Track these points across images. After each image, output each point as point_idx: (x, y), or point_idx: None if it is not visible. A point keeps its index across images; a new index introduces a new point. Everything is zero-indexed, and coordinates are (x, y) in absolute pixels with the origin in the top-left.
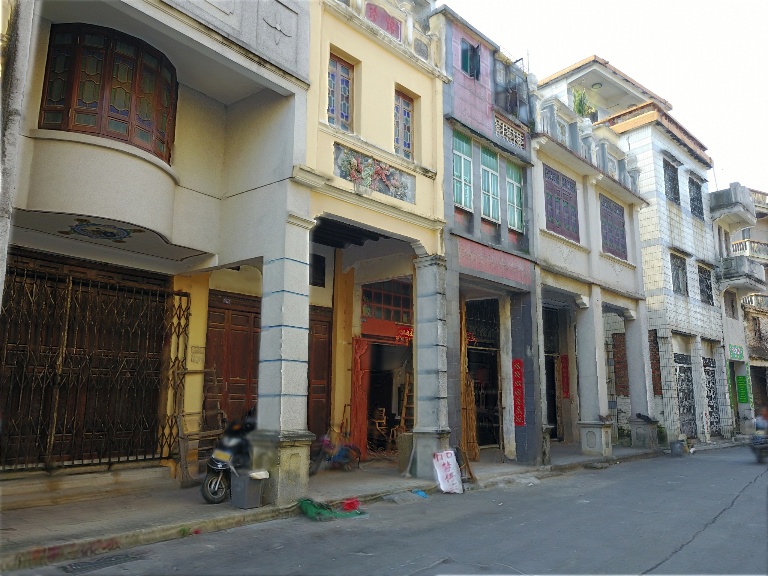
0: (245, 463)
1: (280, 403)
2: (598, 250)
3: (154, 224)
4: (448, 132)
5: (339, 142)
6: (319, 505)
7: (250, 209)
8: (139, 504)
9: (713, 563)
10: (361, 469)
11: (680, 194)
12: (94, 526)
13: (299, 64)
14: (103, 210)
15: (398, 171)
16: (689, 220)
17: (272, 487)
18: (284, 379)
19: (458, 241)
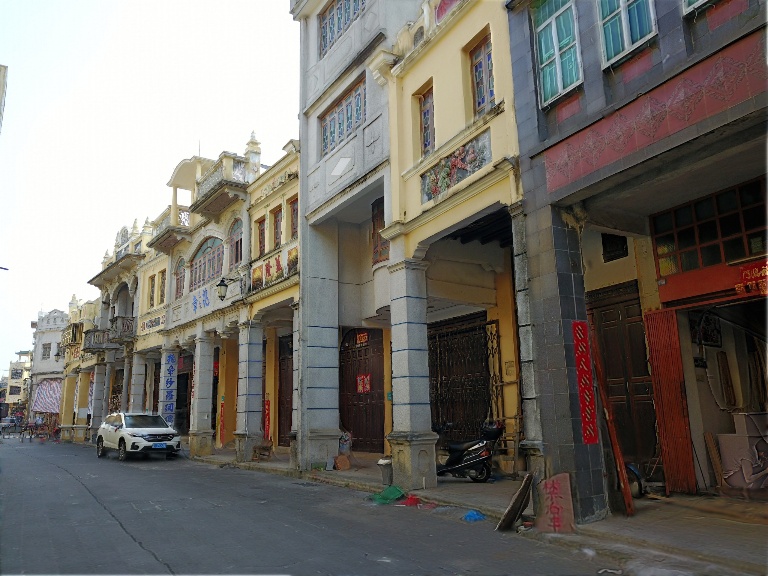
0: None
1: None
2: None
3: None
4: (519, 21)
5: (422, 172)
6: None
7: None
8: None
9: (95, 537)
10: (647, 500)
11: None
12: None
13: (384, 150)
14: None
15: (475, 140)
16: None
17: None
18: (394, 392)
19: (546, 158)
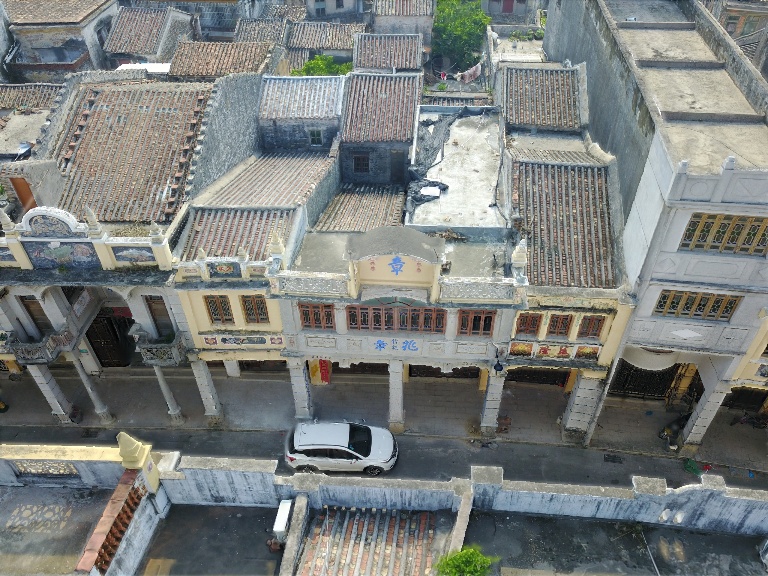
0: (676, 435)
1: (689, 434)
2: None
3: (664, 367)
4: None
5: None
6: (690, 464)
7: (709, 369)
8: (643, 420)
9: None
10: (765, 428)
11: None
12: (619, 438)
13: (742, 347)
14: (644, 367)
15: None
16: None
17: (678, 450)
18: (694, 429)
19: None
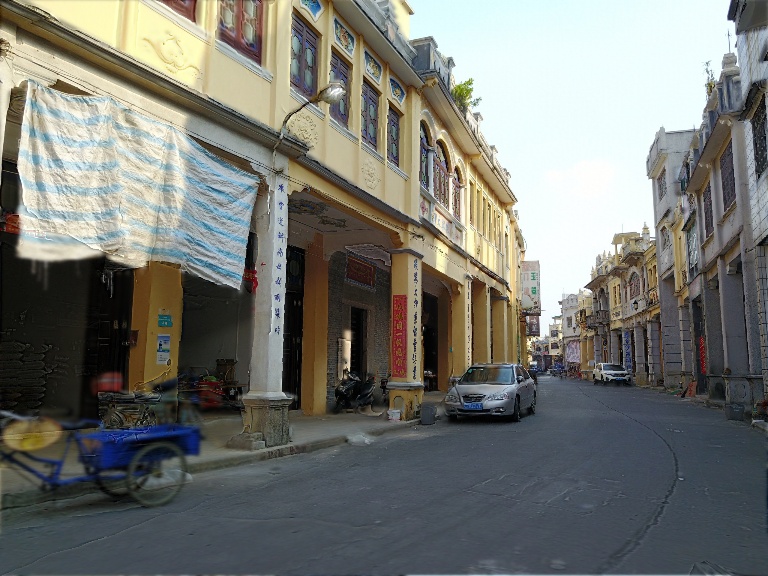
0: None
1: None
2: (719, 221)
3: None
4: None
5: None
6: None
7: None
8: None
9: None
10: None
11: None
12: None
13: None
14: None
15: None
16: None
17: None
18: None
19: None
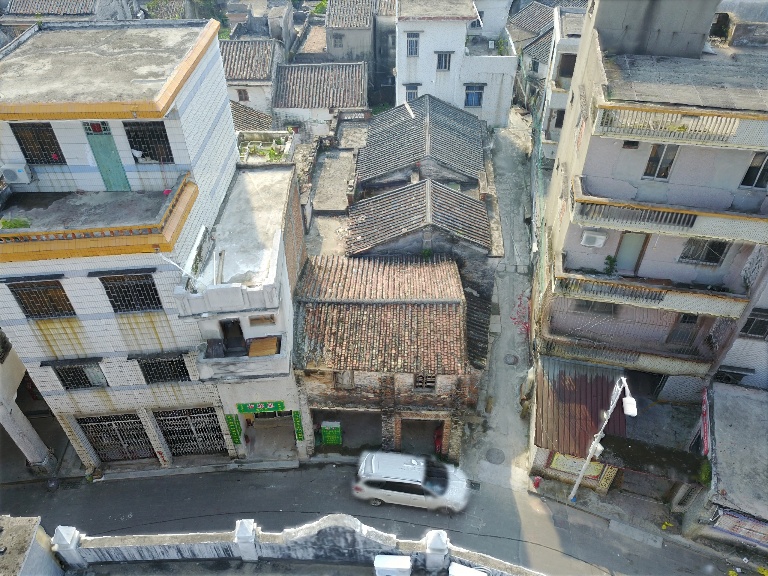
0: None
1: None
2: None
3: None
4: None
5: None
6: None
7: None
8: None
9: None
10: None
11: (73, 304)
12: None
13: None
14: None
15: None
16: (109, 321)
17: None
18: None
19: None
